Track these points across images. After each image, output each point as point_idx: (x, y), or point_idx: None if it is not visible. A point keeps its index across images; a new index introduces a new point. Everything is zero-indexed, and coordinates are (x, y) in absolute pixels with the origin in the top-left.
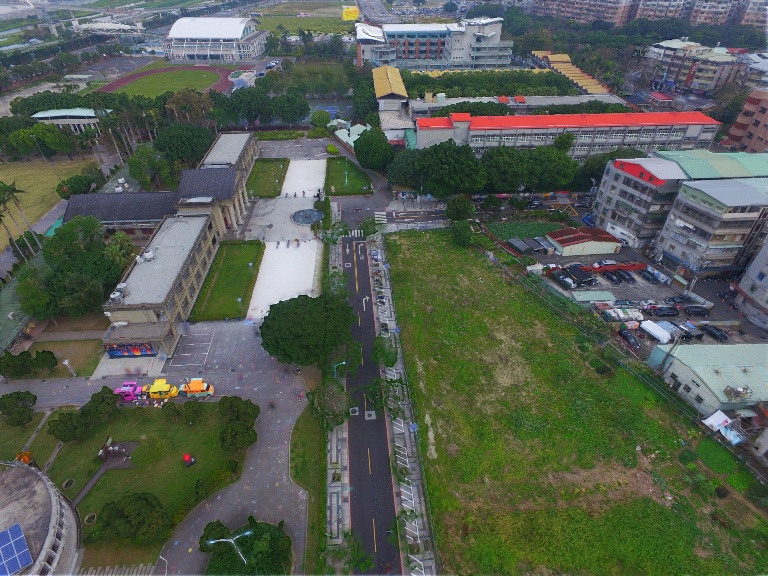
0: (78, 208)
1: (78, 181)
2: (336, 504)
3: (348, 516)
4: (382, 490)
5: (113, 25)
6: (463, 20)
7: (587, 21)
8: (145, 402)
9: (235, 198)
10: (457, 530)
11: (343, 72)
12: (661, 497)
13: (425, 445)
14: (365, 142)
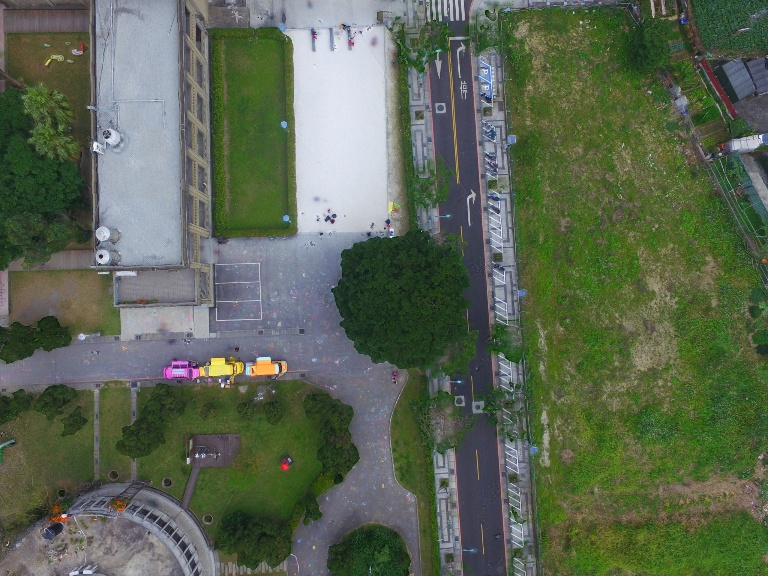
0: None
1: None
2: (446, 511)
3: (457, 522)
4: (490, 497)
5: None
6: None
7: None
8: (207, 380)
9: None
10: (560, 541)
11: None
12: (759, 511)
13: (539, 452)
14: None
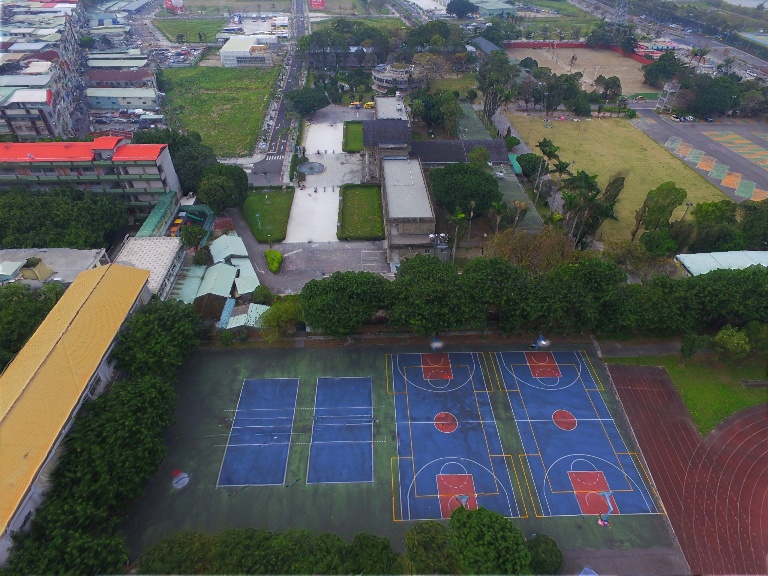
0: None
1: (526, 156)
2: None
3: None
4: None
5: None
6: None
7: None
8: None
9: None
10: None
11: None
12: None
13: None
14: None
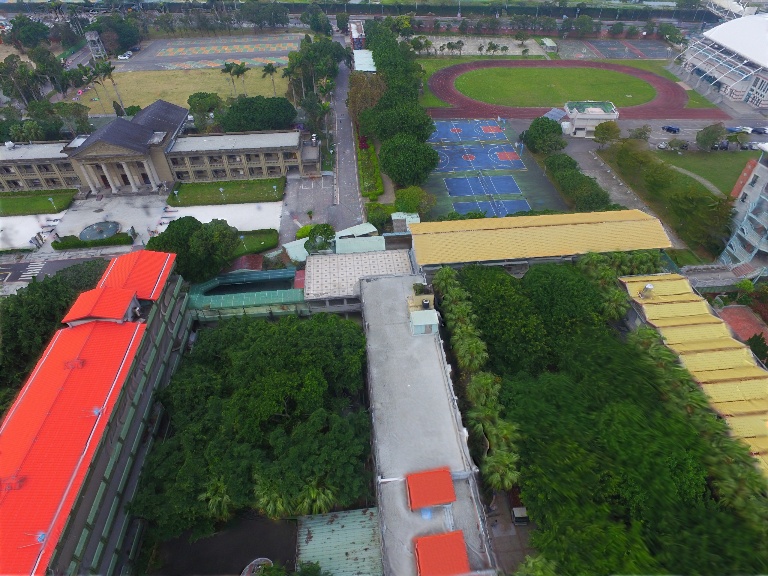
0: None
1: (197, 97)
2: None
3: None
4: None
5: (728, 3)
6: None
7: None
8: None
9: (102, 165)
10: None
11: None
12: None
13: None
14: (170, 224)
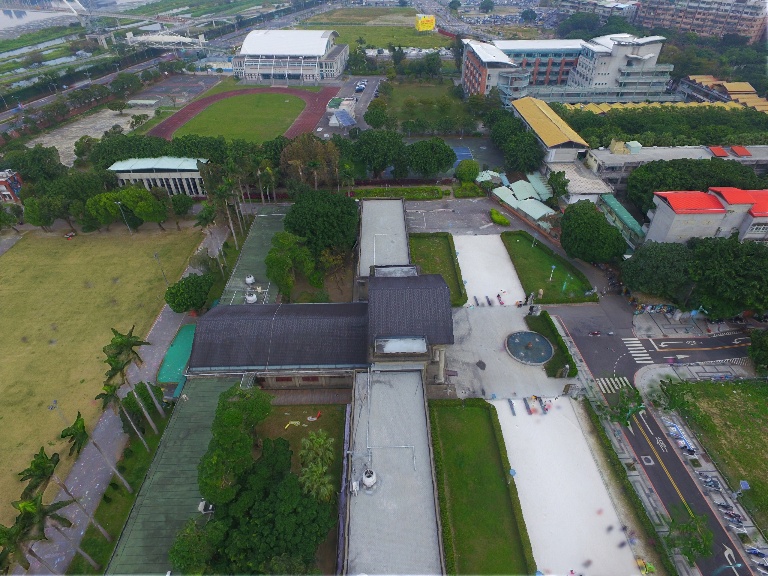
0: (210, 343)
1: (197, 287)
2: None
3: None
4: None
5: (172, 38)
6: (613, 39)
7: (712, 34)
8: None
9: None
10: None
11: (450, 97)
12: None
13: None
14: (587, 227)
